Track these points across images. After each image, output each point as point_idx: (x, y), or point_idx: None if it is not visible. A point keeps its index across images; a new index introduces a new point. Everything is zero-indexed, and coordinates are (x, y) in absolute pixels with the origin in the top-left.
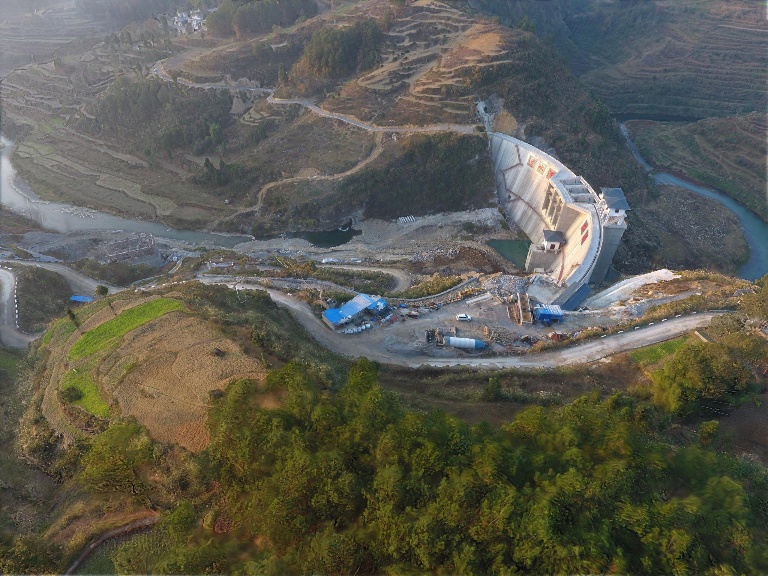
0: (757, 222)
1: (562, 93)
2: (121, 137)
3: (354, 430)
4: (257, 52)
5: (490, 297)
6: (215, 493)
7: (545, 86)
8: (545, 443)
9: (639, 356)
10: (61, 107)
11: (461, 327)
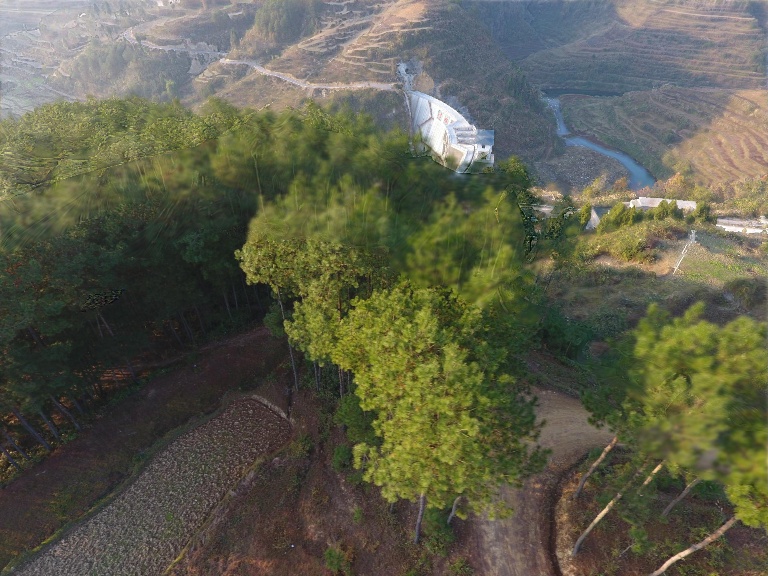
0: (647, 178)
1: (481, 59)
2: (91, 93)
3: None
4: (215, 19)
5: None
6: None
7: (464, 52)
8: None
9: None
10: (42, 67)
11: None
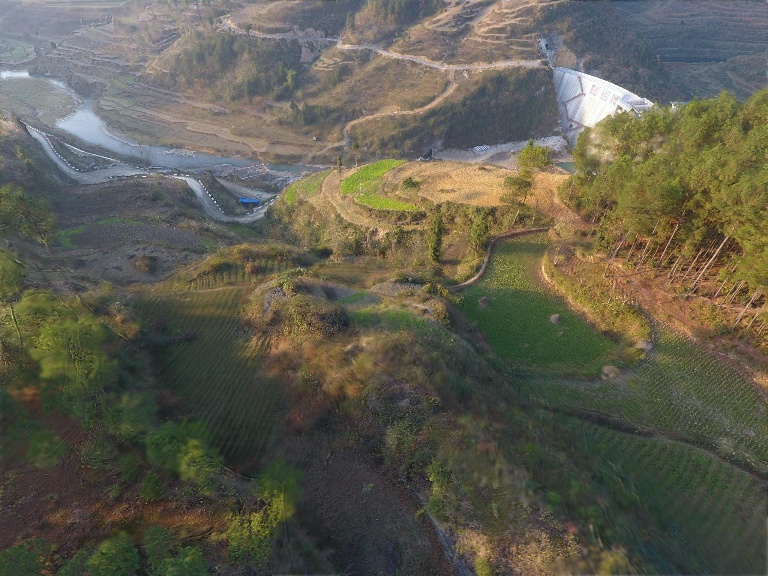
0: None
1: (613, 31)
2: (197, 88)
3: (723, 107)
4: (322, 3)
5: None
6: (553, 217)
7: (598, 24)
8: None
9: None
10: (130, 64)
11: None
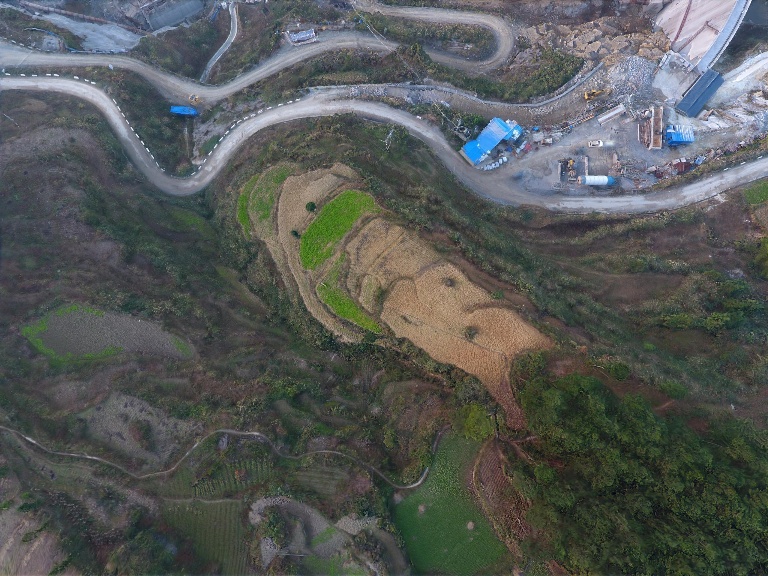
0: None
1: None
2: None
3: (649, 451)
4: None
5: (623, 111)
6: (498, 403)
7: None
8: (754, 469)
9: (751, 194)
10: None
11: (592, 155)
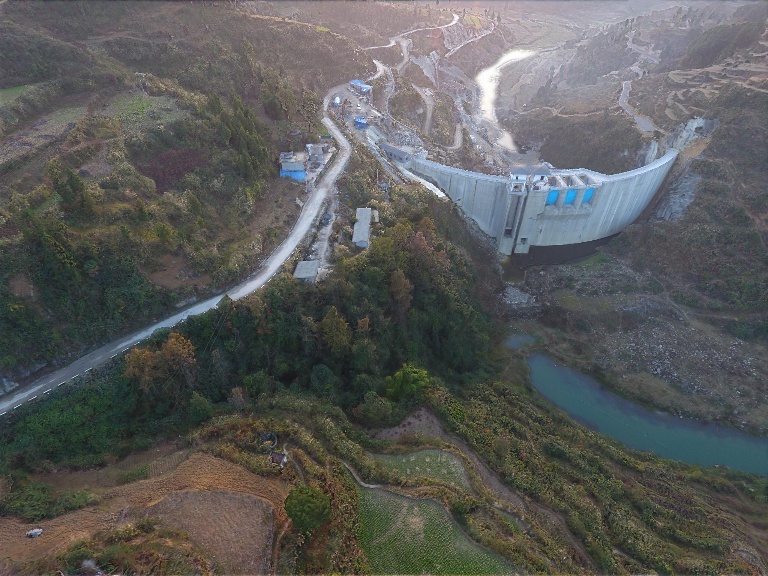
0: None
1: None
2: None
3: None
4: (688, 33)
5: (378, 115)
6: None
7: None
8: None
9: None
10: None
11: None
